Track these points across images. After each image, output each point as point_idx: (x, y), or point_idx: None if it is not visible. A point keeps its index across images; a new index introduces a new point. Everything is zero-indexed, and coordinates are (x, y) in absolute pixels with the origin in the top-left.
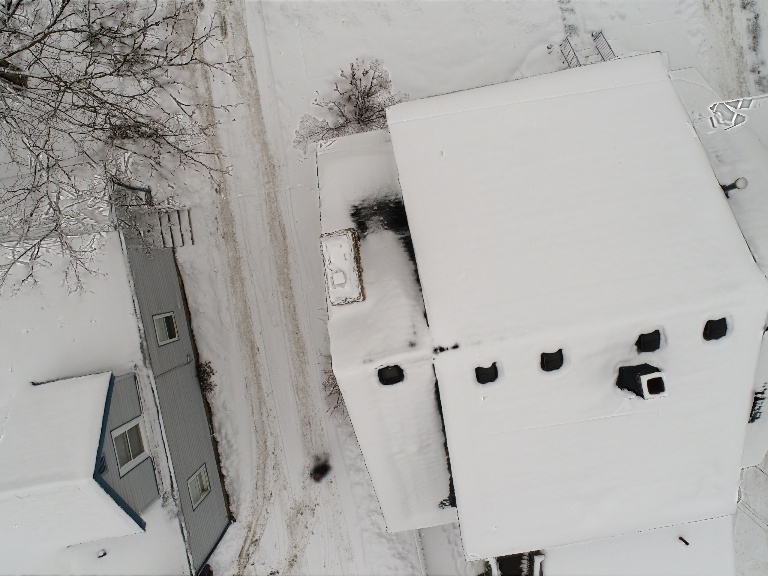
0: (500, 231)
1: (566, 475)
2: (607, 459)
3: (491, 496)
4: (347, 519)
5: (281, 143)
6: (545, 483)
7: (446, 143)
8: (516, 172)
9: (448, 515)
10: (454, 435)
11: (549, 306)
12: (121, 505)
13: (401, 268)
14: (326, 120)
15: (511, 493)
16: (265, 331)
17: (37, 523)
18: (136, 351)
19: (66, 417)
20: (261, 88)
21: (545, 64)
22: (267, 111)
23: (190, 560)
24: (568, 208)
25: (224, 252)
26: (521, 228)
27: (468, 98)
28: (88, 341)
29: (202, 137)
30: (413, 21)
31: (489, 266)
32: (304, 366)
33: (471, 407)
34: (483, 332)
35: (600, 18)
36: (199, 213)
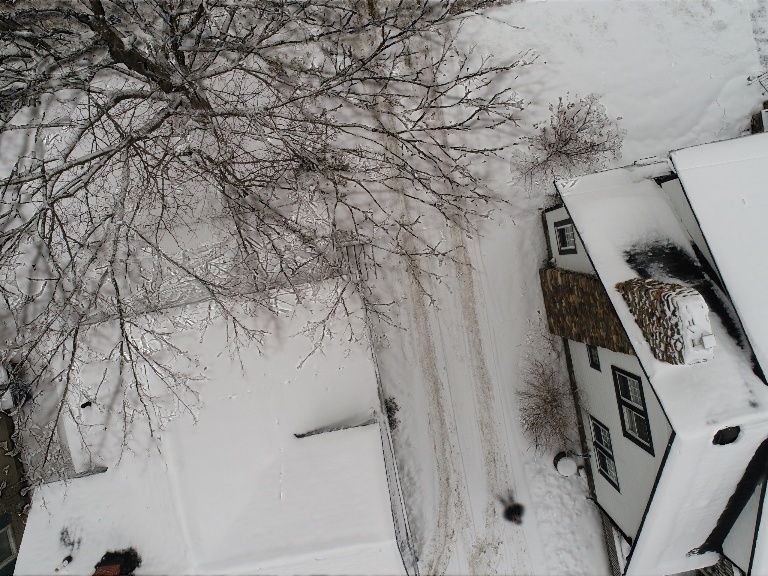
0: None
1: None
2: None
3: None
4: (532, 557)
5: None
6: None
7: (746, 191)
8: None
9: (692, 563)
10: None
11: None
12: None
13: None
14: None
15: None
16: (450, 366)
17: None
18: (375, 397)
19: (347, 473)
20: (447, 119)
21: (744, 96)
22: (453, 142)
23: None
24: None
25: (408, 286)
26: None
27: (761, 144)
28: (338, 389)
29: (385, 169)
30: (606, 52)
31: None
32: (489, 401)
33: None
34: None
35: None
36: (381, 246)
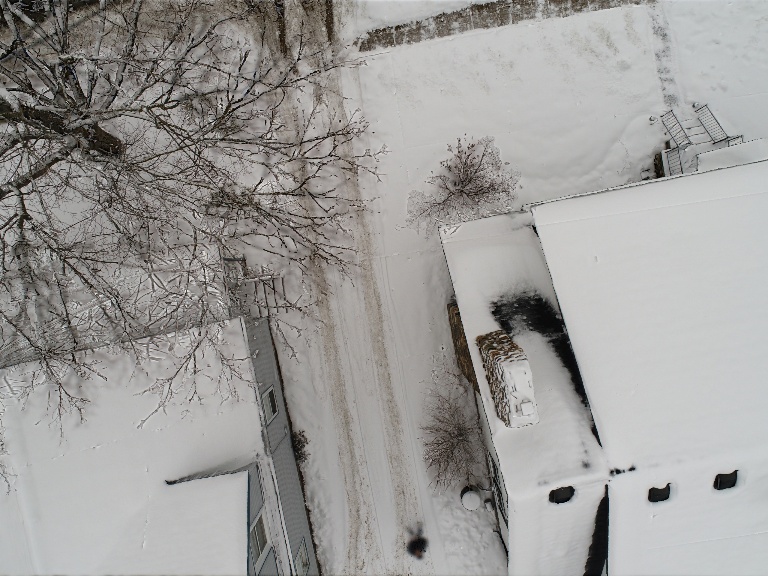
0: (666, 345)
1: None
2: (764, 569)
3: None
4: None
5: (377, 211)
6: None
7: (599, 248)
8: (675, 281)
9: None
10: (619, 551)
11: (725, 427)
12: None
13: (557, 376)
14: (424, 190)
15: None
16: (359, 400)
17: None
18: (258, 440)
19: (209, 522)
20: None
21: (646, 135)
22: (362, 179)
23: None
24: (734, 321)
25: None
26: (687, 342)
27: (618, 200)
28: (216, 434)
29: (296, 204)
30: (512, 91)
31: (659, 382)
32: (398, 435)
33: (640, 525)
34: (660, 454)
35: (701, 89)
36: (292, 280)
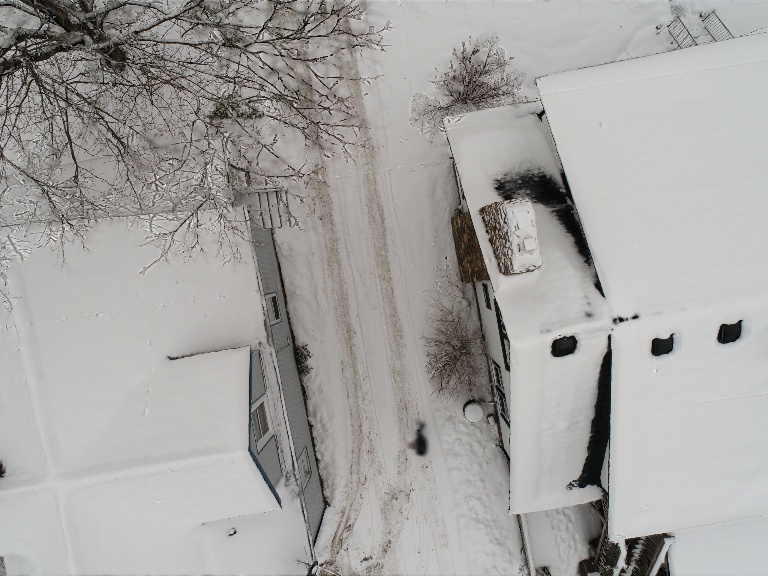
0: (670, 201)
1: (725, 452)
2: None
3: (647, 473)
4: (443, 504)
5: (381, 124)
6: (703, 460)
7: (604, 114)
8: (680, 143)
9: (574, 497)
10: (622, 409)
11: (730, 276)
12: (266, 480)
13: (561, 240)
14: None
15: (667, 470)
16: (362, 314)
17: (181, 498)
18: (260, 328)
19: (211, 391)
20: (361, 68)
21: (653, 45)
22: (367, 92)
23: (310, 541)
24: (739, 179)
25: (321, 234)
26: (692, 198)
27: (623, 69)
28: (218, 317)
29: (300, 118)
30: (518, 1)
31: (663, 236)
32: (401, 349)
33: (643, 380)
34: (663, 302)
35: None
36: None
